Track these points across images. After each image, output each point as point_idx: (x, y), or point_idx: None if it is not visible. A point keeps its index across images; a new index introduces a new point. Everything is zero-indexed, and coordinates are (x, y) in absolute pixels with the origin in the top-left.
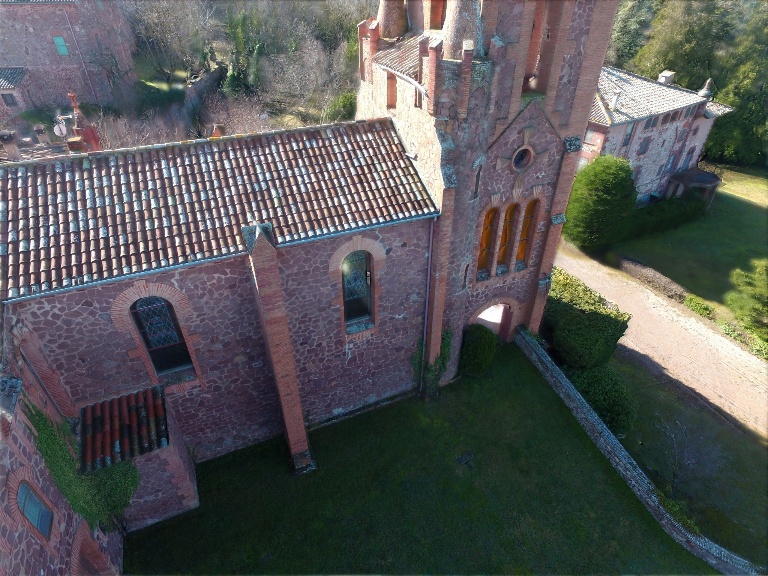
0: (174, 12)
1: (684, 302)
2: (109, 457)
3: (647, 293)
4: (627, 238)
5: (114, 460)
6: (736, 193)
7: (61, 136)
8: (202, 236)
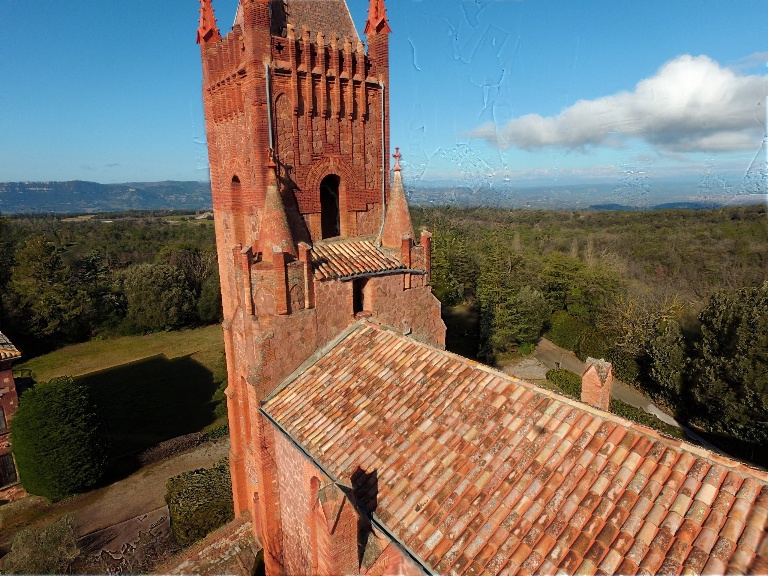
0: None
1: (209, 438)
2: None
3: (187, 457)
4: None
5: None
6: None
7: None
8: None
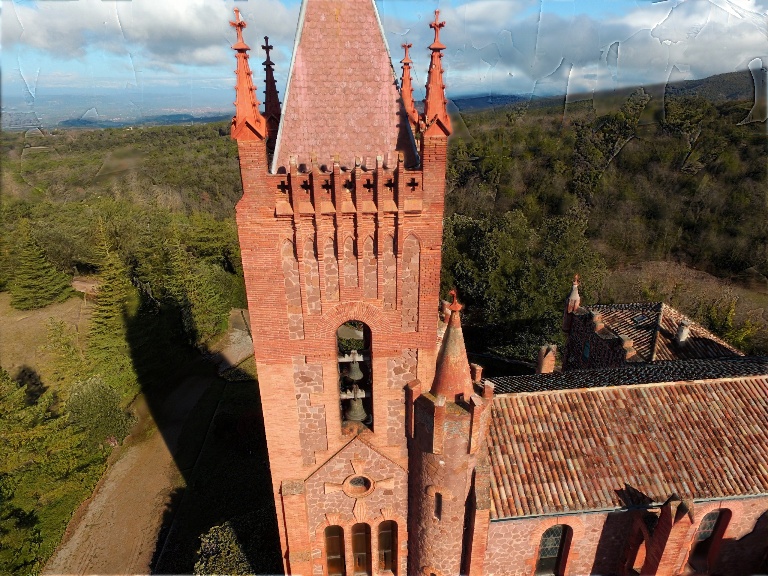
0: None
1: None
2: None
3: None
4: None
5: None
6: None
7: None
8: None
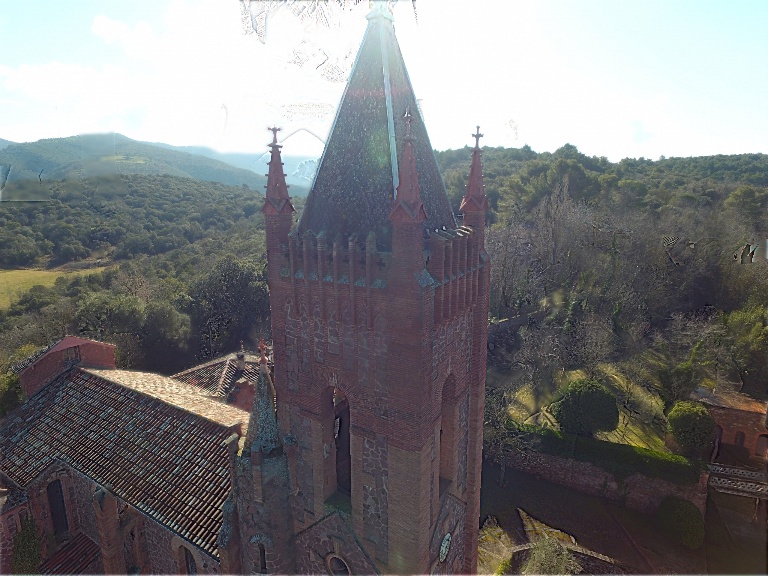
0: None
1: None
2: (50, 570)
3: None
4: None
5: (48, 574)
6: None
7: (271, 361)
8: None
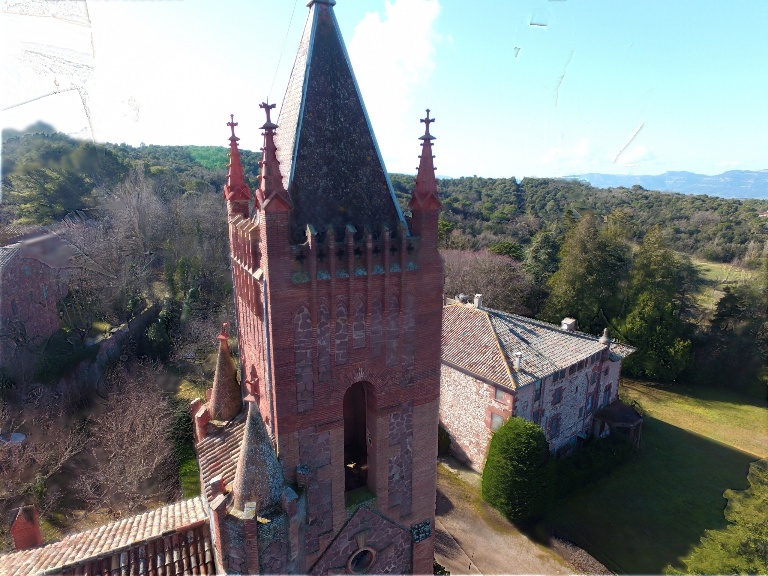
0: (96, 281)
1: None
2: None
3: None
4: (558, 497)
5: None
6: (664, 418)
7: None
8: None
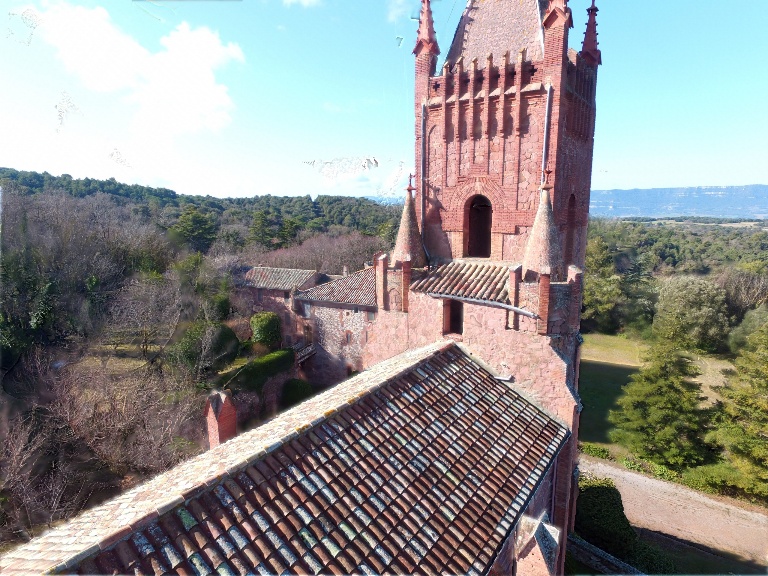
0: None
1: (584, 451)
2: None
3: None
4: None
5: None
6: None
7: None
8: (427, 572)
